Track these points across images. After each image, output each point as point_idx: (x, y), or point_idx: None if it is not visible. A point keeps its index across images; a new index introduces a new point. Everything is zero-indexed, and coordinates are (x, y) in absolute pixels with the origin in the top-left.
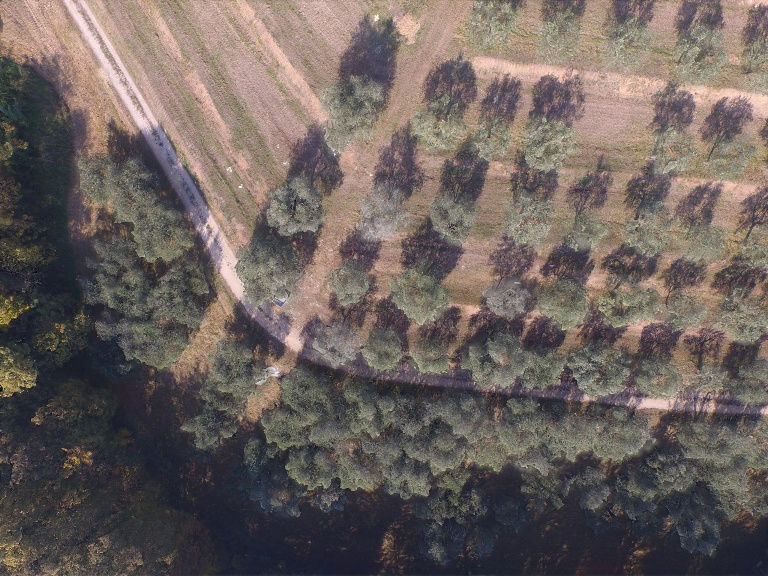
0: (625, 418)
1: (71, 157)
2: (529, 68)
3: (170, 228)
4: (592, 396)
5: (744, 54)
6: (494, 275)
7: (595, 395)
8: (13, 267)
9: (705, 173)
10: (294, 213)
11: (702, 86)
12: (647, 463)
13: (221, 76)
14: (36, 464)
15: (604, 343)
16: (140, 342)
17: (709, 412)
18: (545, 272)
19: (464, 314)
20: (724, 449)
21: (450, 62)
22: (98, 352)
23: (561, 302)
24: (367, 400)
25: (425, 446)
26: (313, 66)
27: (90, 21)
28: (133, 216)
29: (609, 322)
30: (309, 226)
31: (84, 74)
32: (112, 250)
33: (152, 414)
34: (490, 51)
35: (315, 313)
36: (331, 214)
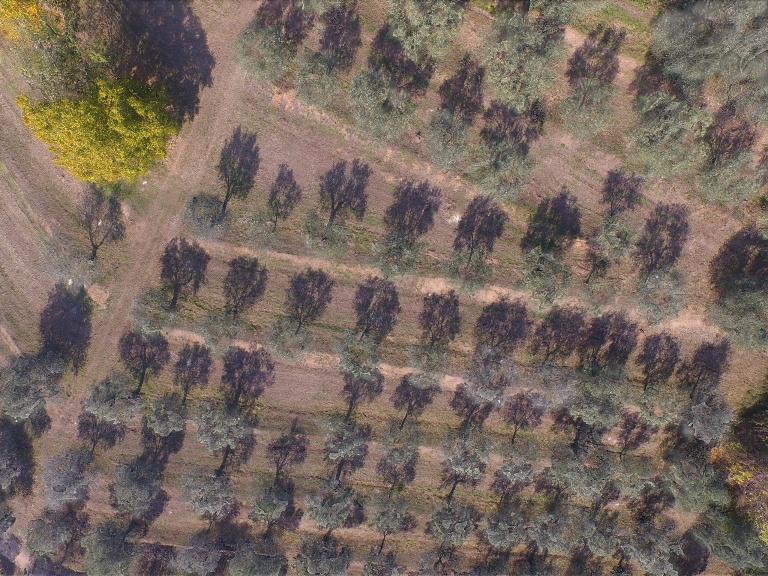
0: None
1: None
2: None
3: None
4: None
5: (423, 336)
6: (203, 519)
7: None
8: None
9: (399, 438)
10: None
11: (384, 364)
12: None
13: None
14: None
15: None
16: None
17: None
18: (254, 518)
19: (182, 549)
20: None
21: (140, 328)
22: None
23: (241, 571)
24: None
25: None
26: (15, 319)
27: None
28: None
29: None
30: None
31: None
32: None
33: None
34: (176, 322)
35: None
36: (42, 455)
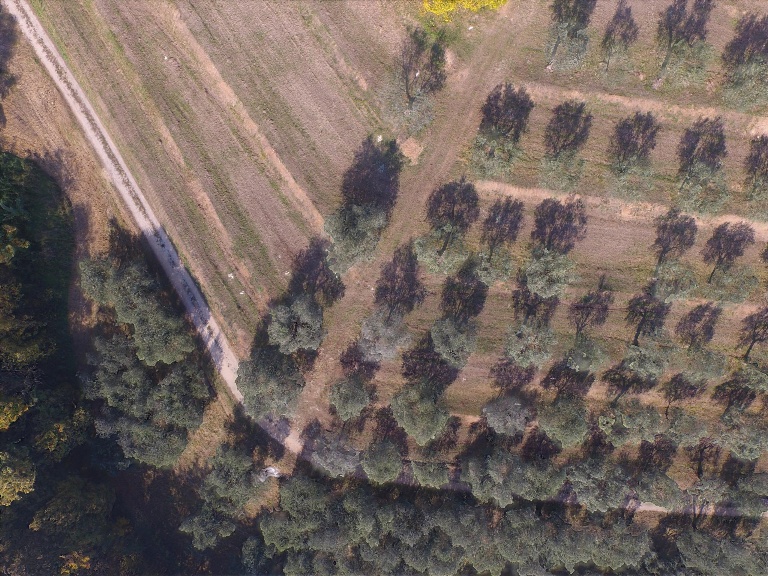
0: (624, 520)
1: (73, 251)
2: (532, 192)
3: (171, 336)
4: (591, 510)
5: (746, 182)
6: (494, 387)
7: (594, 510)
8: (13, 366)
9: (706, 293)
10: (295, 334)
11: None
12: (646, 567)
13: (224, 185)
14: (33, 572)
15: (604, 450)
16: (139, 442)
17: (708, 514)
18: (546, 384)
19: (464, 422)
20: (723, 562)
21: (453, 184)
22: (97, 447)
23: (561, 425)
24: (366, 511)
25: (424, 555)
26: (316, 182)
27: (93, 121)
28: (134, 319)
29: (609, 440)
30: (310, 345)
31: (87, 170)
32: (112, 349)
33: (150, 502)
34: (493, 175)
35: (315, 417)
36: (332, 325)
